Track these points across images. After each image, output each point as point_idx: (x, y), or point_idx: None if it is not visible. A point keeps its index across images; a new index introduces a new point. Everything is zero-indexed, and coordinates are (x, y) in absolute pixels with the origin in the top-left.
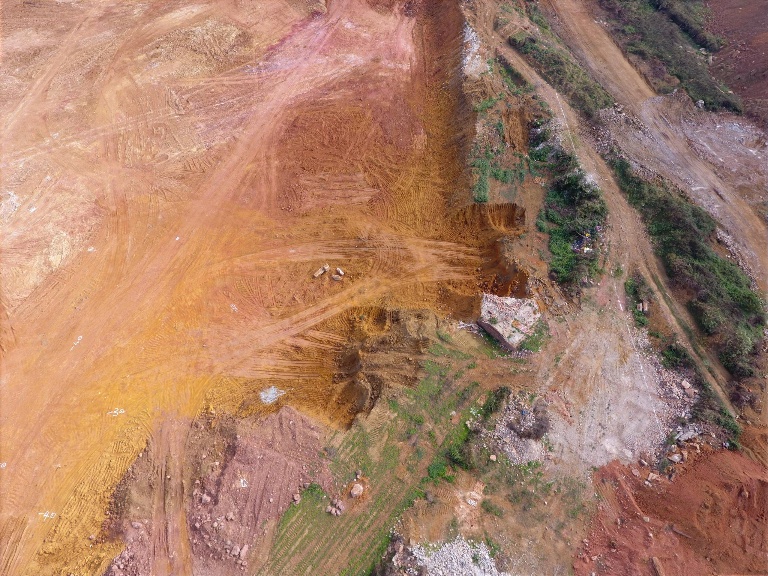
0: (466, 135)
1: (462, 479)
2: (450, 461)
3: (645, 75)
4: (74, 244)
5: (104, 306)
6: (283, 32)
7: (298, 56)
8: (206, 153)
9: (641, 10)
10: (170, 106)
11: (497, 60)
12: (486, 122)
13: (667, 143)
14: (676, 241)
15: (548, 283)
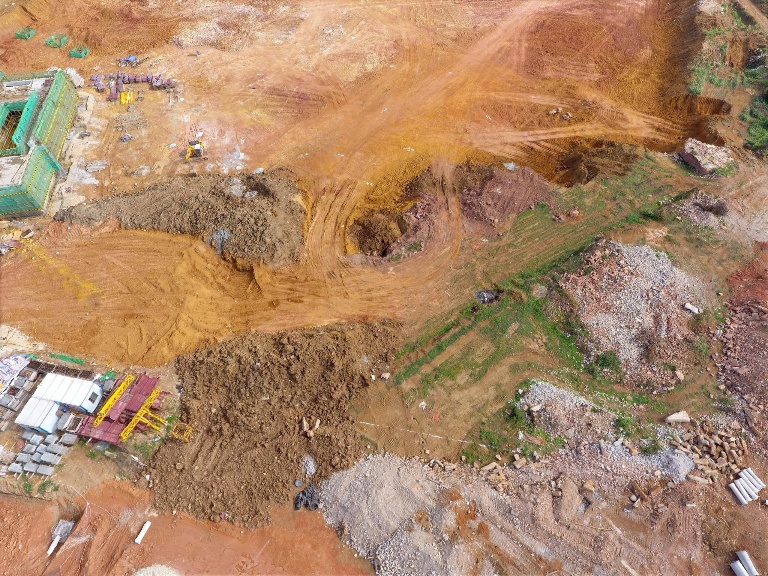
0: (691, 50)
1: (652, 224)
2: (644, 216)
3: None
4: (381, 61)
5: (401, 96)
6: None
7: None
8: (474, 29)
9: None
10: None
11: (732, 5)
12: (712, 43)
13: None
14: None
15: (742, 149)
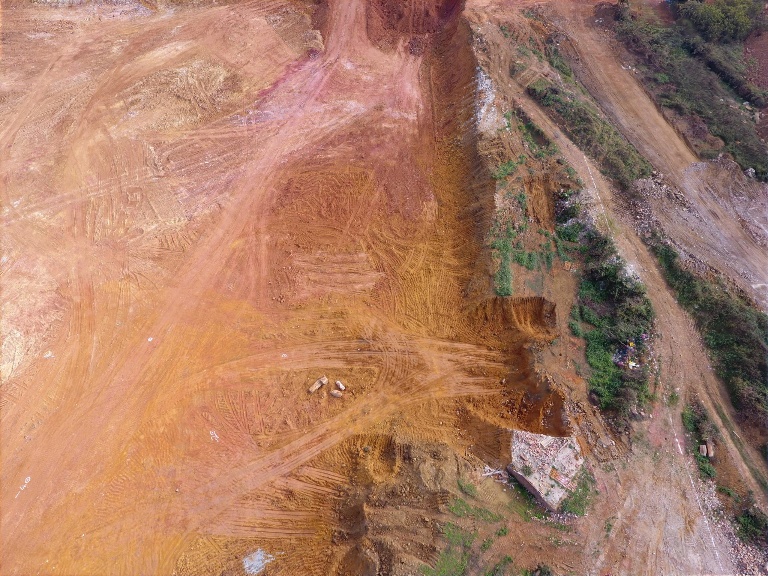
0: (483, 208)
1: None
2: None
3: (684, 135)
4: (29, 348)
5: (59, 434)
6: (276, 74)
7: (292, 103)
8: (187, 226)
9: (674, 54)
10: (148, 166)
11: (515, 113)
12: (506, 193)
13: (717, 224)
14: (742, 362)
15: (588, 409)
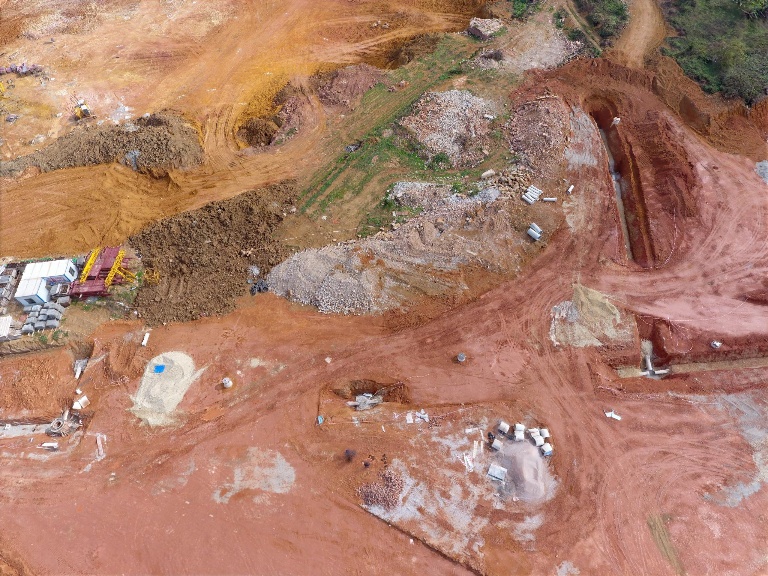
0: None
1: (456, 76)
2: (451, 73)
3: None
4: (225, 15)
5: (250, 38)
6: None
7: None
8: None
9: None
10: None
11: None
12: None
13: None
14: None
15: None
